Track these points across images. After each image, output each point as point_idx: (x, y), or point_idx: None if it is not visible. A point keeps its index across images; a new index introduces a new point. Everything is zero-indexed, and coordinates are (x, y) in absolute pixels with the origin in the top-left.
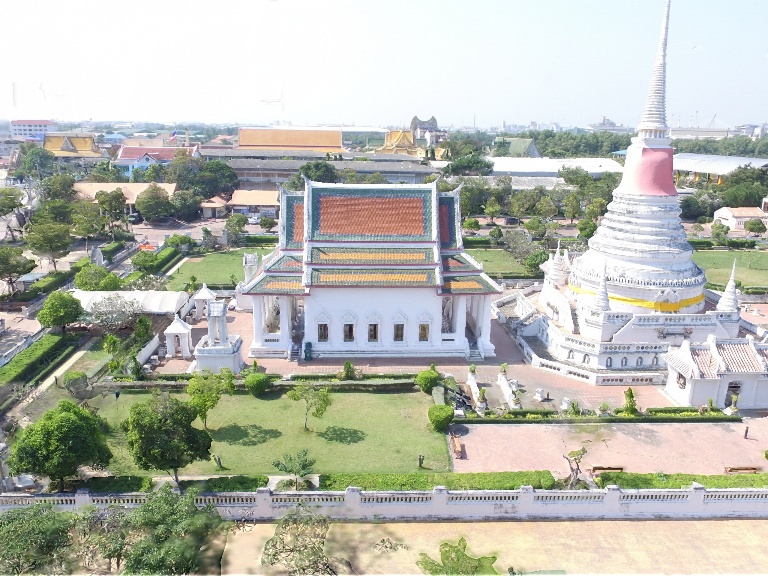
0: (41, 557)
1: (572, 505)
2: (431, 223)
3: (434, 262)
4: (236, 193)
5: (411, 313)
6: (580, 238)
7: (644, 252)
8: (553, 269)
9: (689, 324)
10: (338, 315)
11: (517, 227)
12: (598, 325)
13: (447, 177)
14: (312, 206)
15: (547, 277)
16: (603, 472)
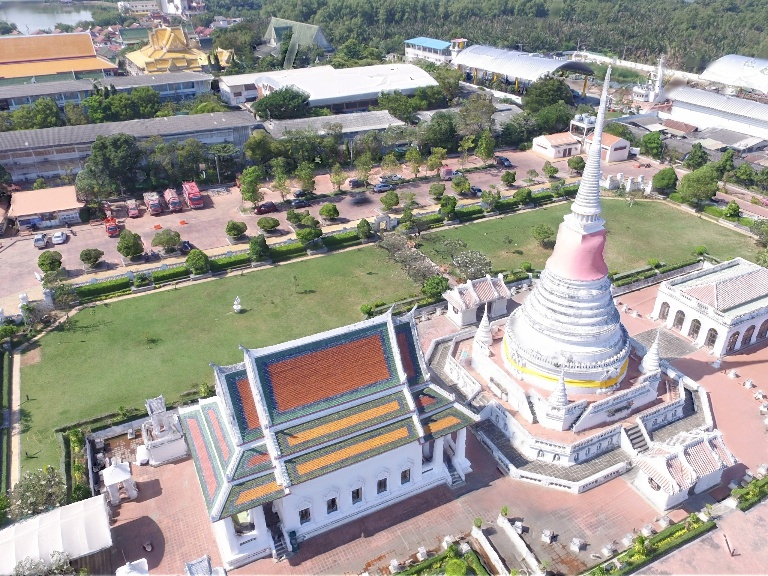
0: None
1: None
2: (394, 361)
3: (410, 410)
4: (15, 198)
5: (393, 465)
6: (443, 214)
7: (589, 337)
8: (482, 332)
9: (631, 397)
10: (319, 495)
11: (365, 192)
12: (559, 419)
13: (260, 115)
14: (260, 381)
15: (477, 340)
16: None
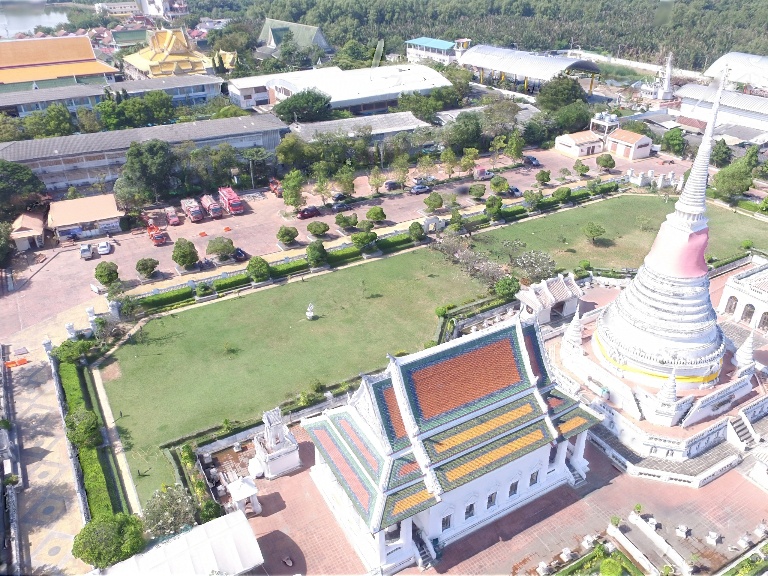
0: None
1: None
2: (523, 364)
3: (543, 412)
4: (54, 208)
5: (525, 467)
6: (489, 215)
7: (693, 333)
8: (574, 331)
9: (732, 391)
10: (461, 501)
11: (403, 193)
12: (669, 415)
13: (282, 118)
14: (406, 389)
15: (568, 339)
16: None
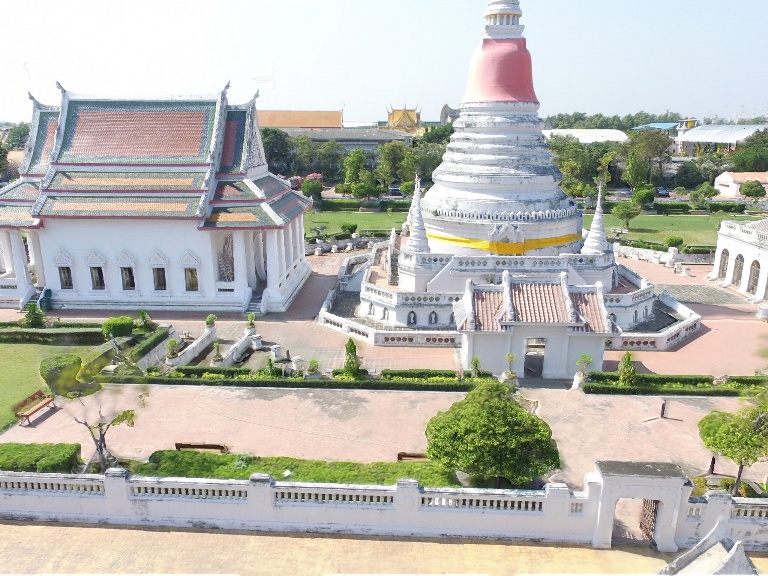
0: None
1: (52, 499)
2: (210, 142)
3: (200, 188)
4: None
5: (173, 254)
6: None
7: (480, 176)
8: None
9: (529, 270)
10: (82, 255)
11: None
12: (410, 271)
13: None
14: (66, 122)
15: None
16: (164, 450)
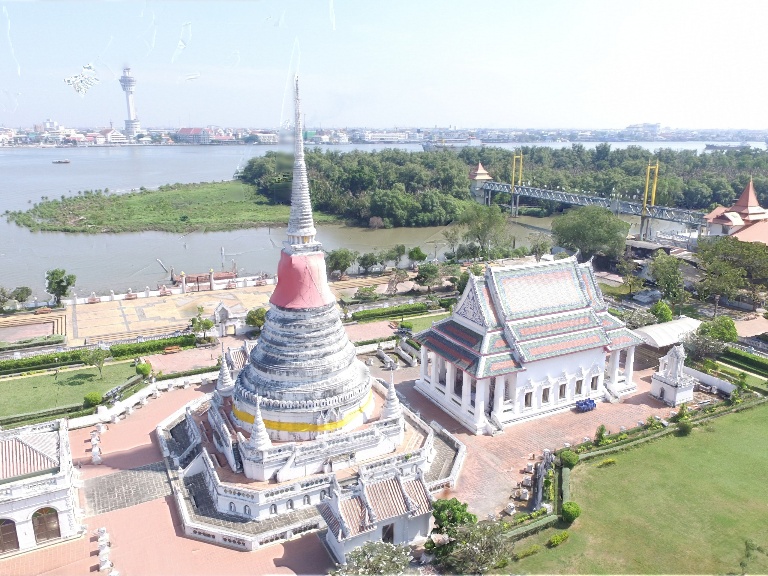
0: (444, 266)
1: None
2: None
3: None
4: None
5: None
6: None
7: None
8: None
9: None
10: None
11: None
12: None
13: None
14: None
15: None
16: None
